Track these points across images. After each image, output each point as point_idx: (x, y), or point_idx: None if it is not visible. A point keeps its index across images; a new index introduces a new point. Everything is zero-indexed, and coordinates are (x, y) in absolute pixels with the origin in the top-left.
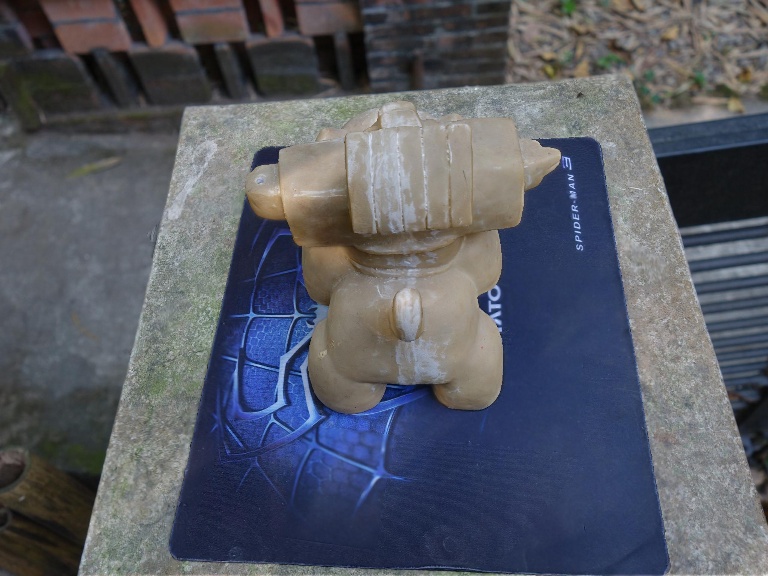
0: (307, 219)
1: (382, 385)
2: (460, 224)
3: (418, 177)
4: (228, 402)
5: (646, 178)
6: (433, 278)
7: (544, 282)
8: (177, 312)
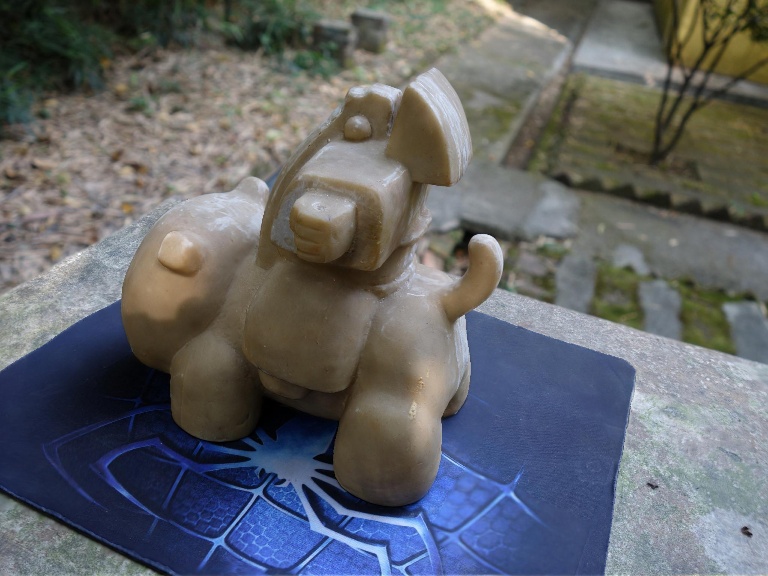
0: (395, 213)
1: None
2: None
3: None
4: None
5: None
6: (418, 267)
7: None
8: None
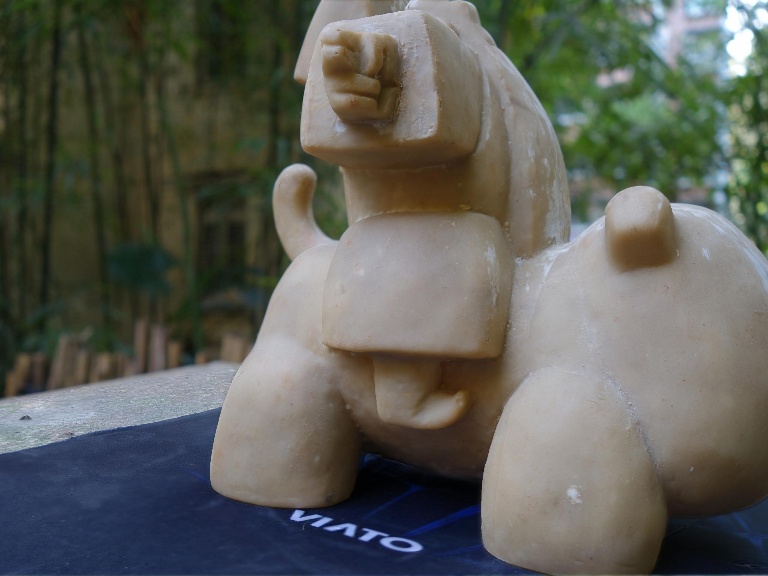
0: None
1: None
2: None
3: None
4: None
5: None
6: None
7: None
8: None
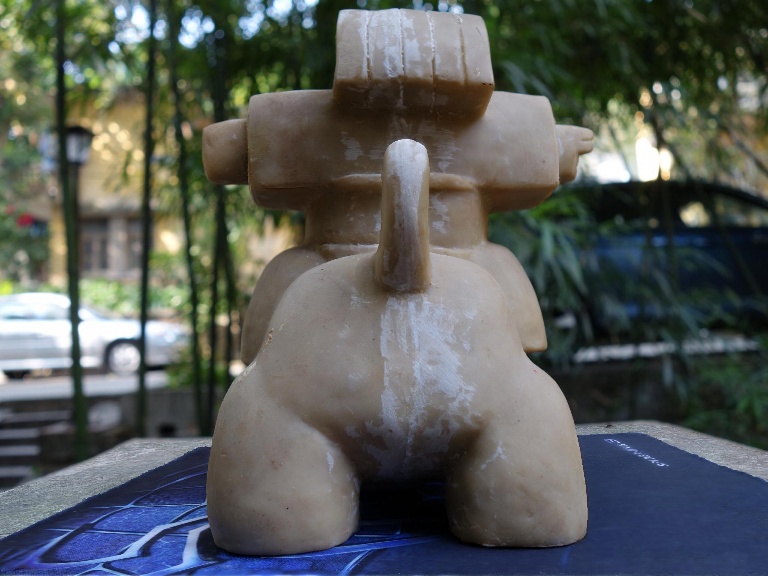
0: (275, 120)
1: (348, 477)
2: (478, 76)
3: (423, 24)
4: (18, 556)
5: (725, 447)
6: None
7: (622, 478)
8: (1, 514)
